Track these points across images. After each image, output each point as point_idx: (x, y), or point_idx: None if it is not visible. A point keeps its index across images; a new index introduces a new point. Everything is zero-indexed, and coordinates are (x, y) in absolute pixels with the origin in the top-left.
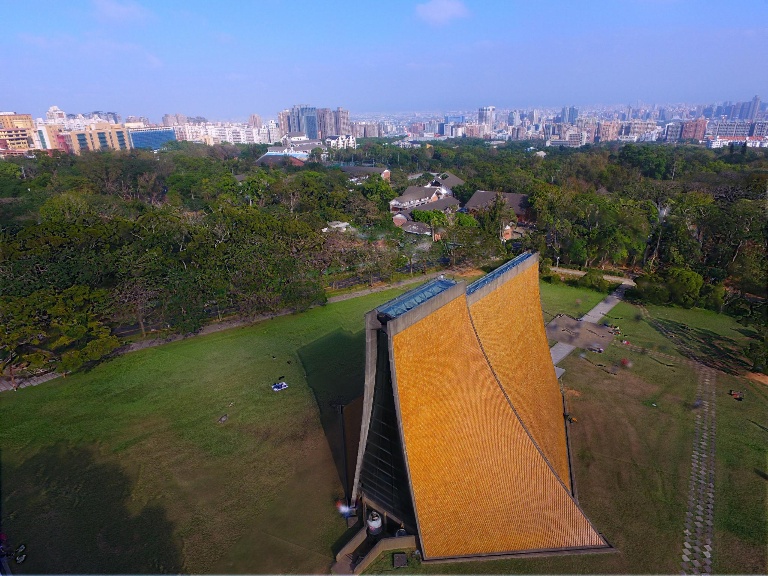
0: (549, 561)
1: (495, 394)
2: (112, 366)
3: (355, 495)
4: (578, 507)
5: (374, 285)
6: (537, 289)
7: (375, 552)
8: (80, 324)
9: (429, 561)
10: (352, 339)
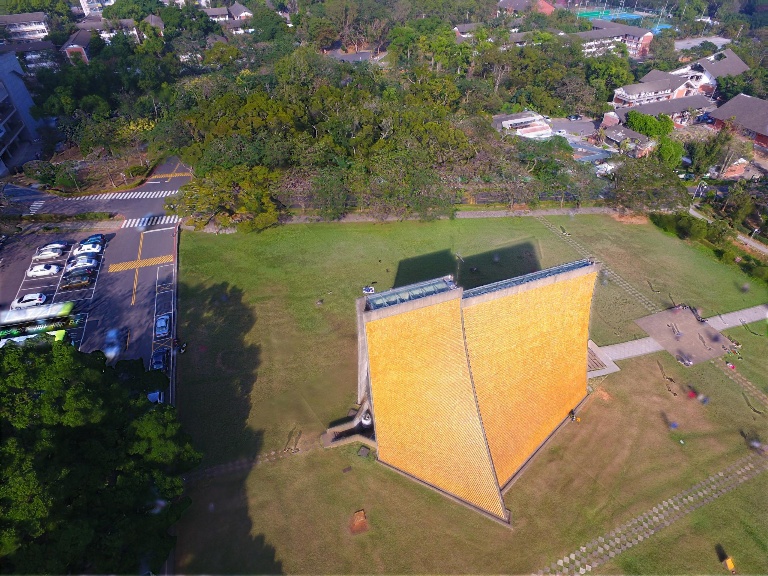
0: (456, 506)
1: (463, 381)
2: (274, 233)
3: (360, 398)
4: (497, 486)
5: (514, 207)
6: (589, 296)
7: (350, 439)
8: (256, 199)
9: (380, 462)
10: (451, 264)
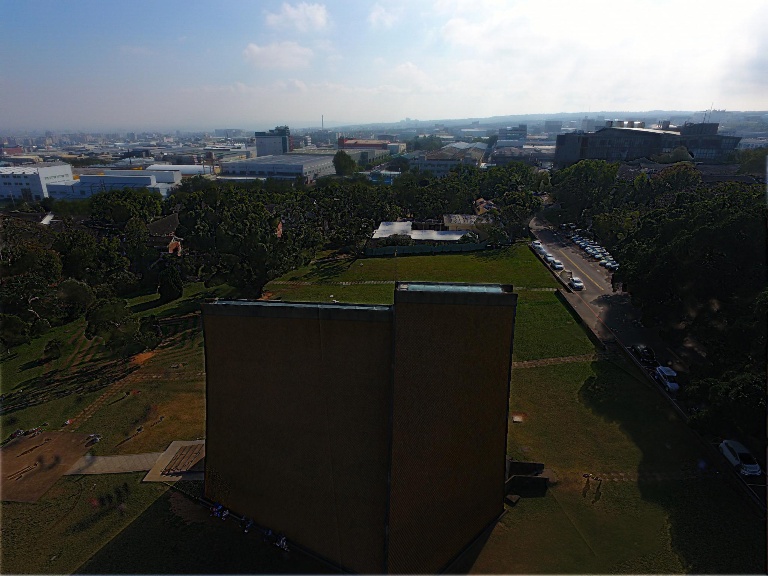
0: None
1: None
2: None
3: None
4: None
5: None
6: None
7: None
8: None
9: None
10: None
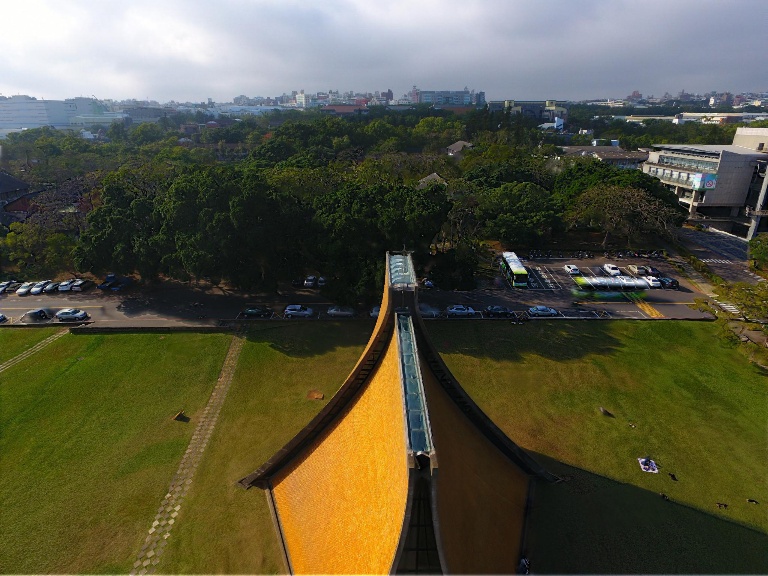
0: None
1: None
2: None
3: None
4: None
5: None
6: None
7: None
8: None
9: None
10: None
